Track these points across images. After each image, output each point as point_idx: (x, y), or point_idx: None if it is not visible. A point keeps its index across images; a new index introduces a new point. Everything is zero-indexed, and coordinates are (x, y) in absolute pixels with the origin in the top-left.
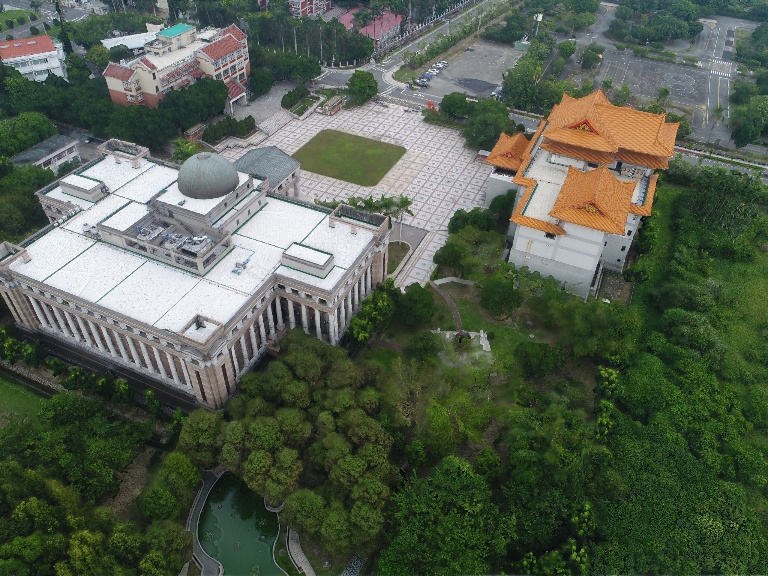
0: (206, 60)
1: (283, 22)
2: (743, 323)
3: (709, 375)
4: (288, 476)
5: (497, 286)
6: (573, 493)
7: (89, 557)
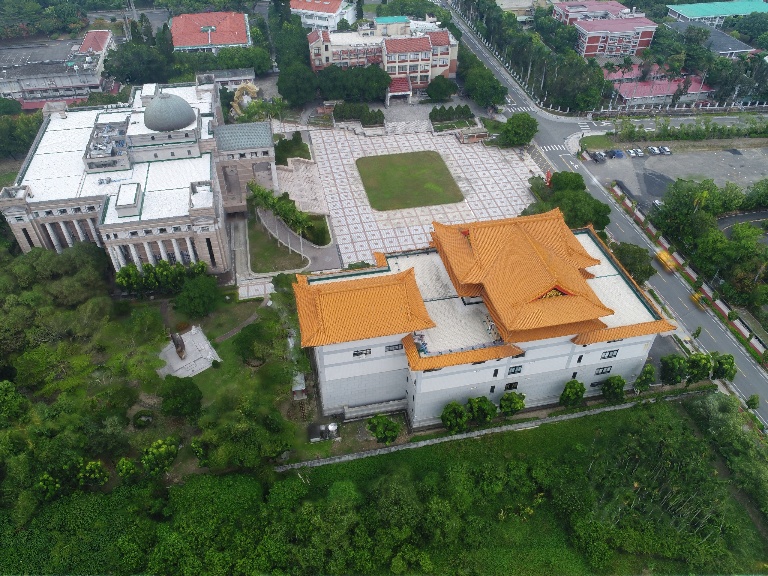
0: (384, 50)
1: (526, 46)
2: None
3: (281, 569)
4: None
5: (253, 328)
6: (6, 481)
7: None
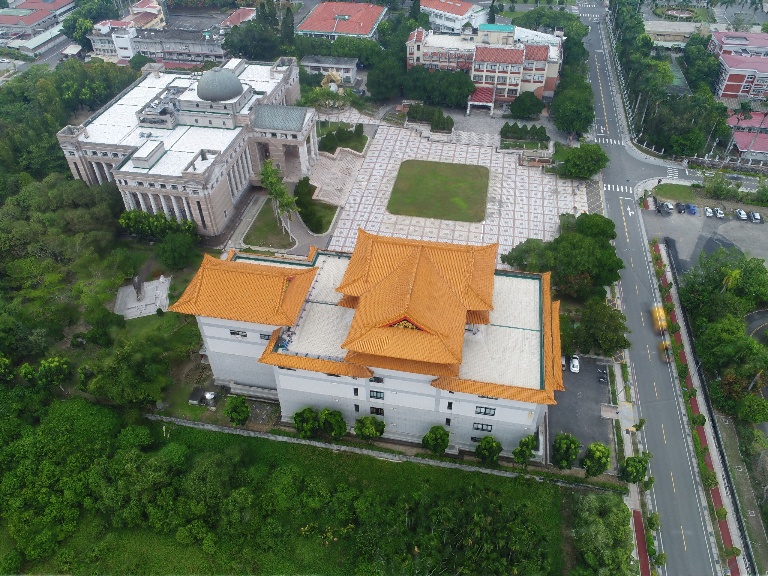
0: None
1: (641, 74)
2: (202, 571)
3: (94, 499)
4: (3, 216)
5: None
6: None
7: None
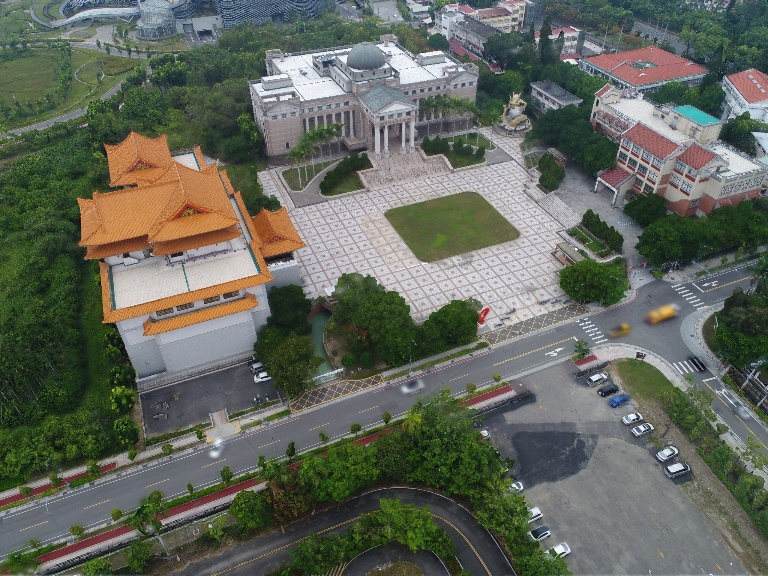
0: None
1: None
2: (5, 281)
3: None
4: None
5: None
6: None
7: (245, 57)
